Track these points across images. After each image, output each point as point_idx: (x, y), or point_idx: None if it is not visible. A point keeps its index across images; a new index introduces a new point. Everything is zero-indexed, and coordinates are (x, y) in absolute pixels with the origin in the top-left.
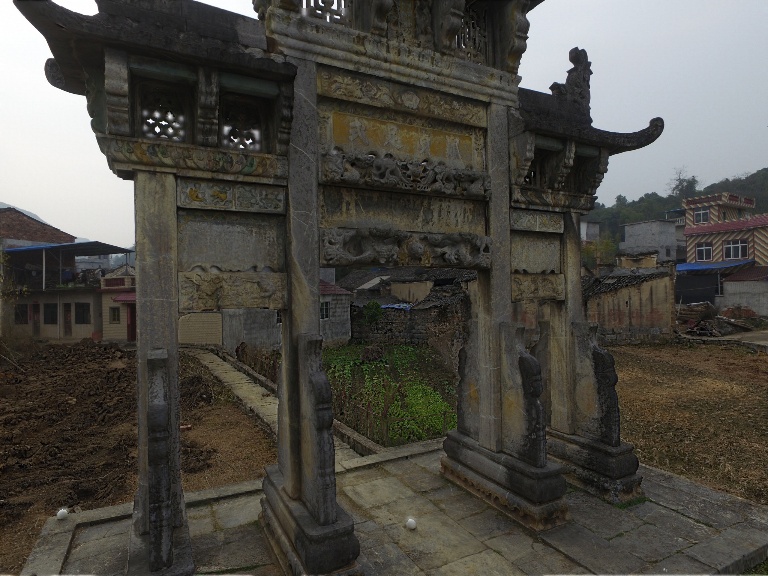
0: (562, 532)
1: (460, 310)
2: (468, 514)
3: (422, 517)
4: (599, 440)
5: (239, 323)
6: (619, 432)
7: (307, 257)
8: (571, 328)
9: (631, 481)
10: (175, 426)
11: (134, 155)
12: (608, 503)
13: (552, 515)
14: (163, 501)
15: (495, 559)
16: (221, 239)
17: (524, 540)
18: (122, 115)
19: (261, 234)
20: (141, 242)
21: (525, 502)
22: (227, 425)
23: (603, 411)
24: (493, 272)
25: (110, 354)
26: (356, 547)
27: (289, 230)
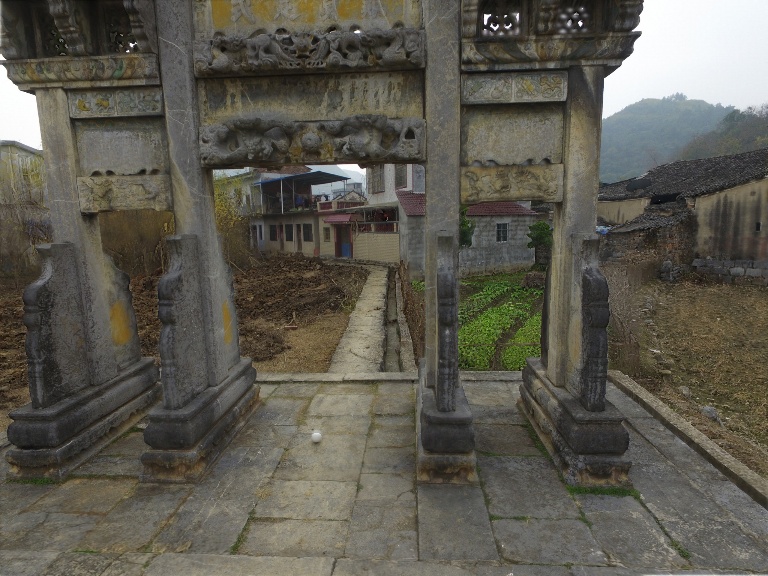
0: (448, 491)
1: (678, 234)
2: (385, 445)
3: (341, 435)
4: (578, 399)
5: (406, 243)
6: (603, 393)
7: (185, 158)
8: (570, 242)
9: (604, 462)
10: (86, 307)
11: (27, 75)
12: (561, 481)
13: (445, 469)
14: (35, 358)
15: (345, 492)
16: (112, 145)
17: (402, 485)
18: (4, 40)
19: (147, 138)
20: (45, 152)
21: (421, 446)
22: (324, 330)
23: (583, 361)
24: (428, 165)
25: (312, 266)
26: (187, 435)
27: (167, 131)
